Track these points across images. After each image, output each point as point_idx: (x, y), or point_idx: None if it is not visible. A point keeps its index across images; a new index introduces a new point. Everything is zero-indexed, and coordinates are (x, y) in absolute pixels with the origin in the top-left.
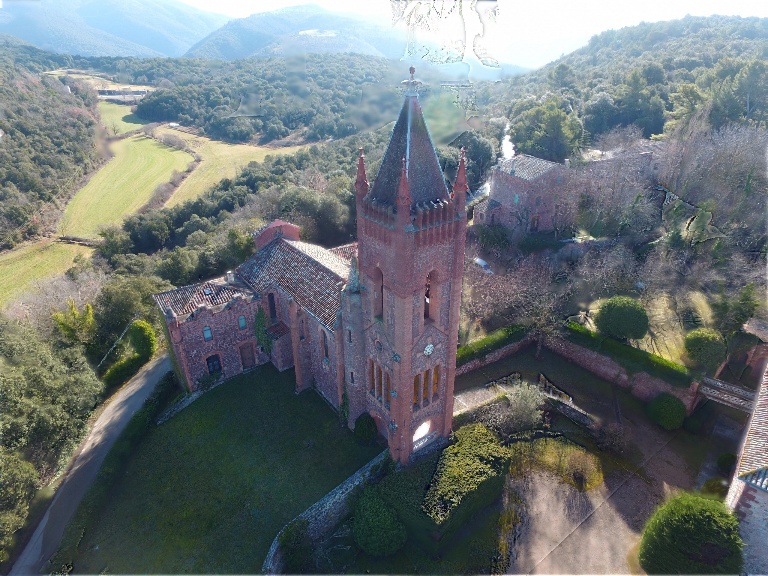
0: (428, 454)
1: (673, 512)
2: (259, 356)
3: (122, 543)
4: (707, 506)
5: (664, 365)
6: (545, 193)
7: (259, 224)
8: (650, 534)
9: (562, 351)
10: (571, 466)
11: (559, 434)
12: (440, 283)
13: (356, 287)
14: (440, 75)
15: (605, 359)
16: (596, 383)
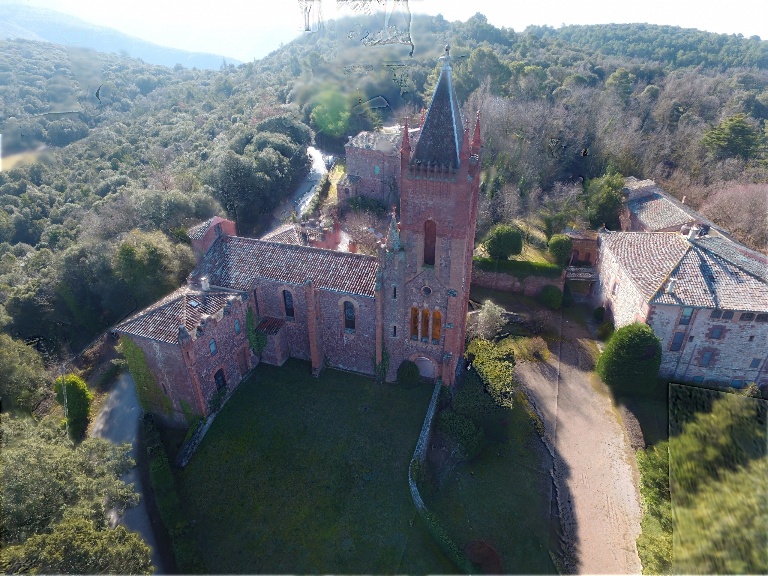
0: (460, 374)
1: (622, 339)
2: (251, 359)
3: (260, 572)
4: (638, 326)
5: (543, 266)
6: (399, 161)
7: (146, 235)
8: (610, 361)
9: None
10: (534, 348)
11: (508, 334)
12: (469, 224)
13: (398, 246)
14: (380, 56)
15: (502, 275)
16: (502, 295)
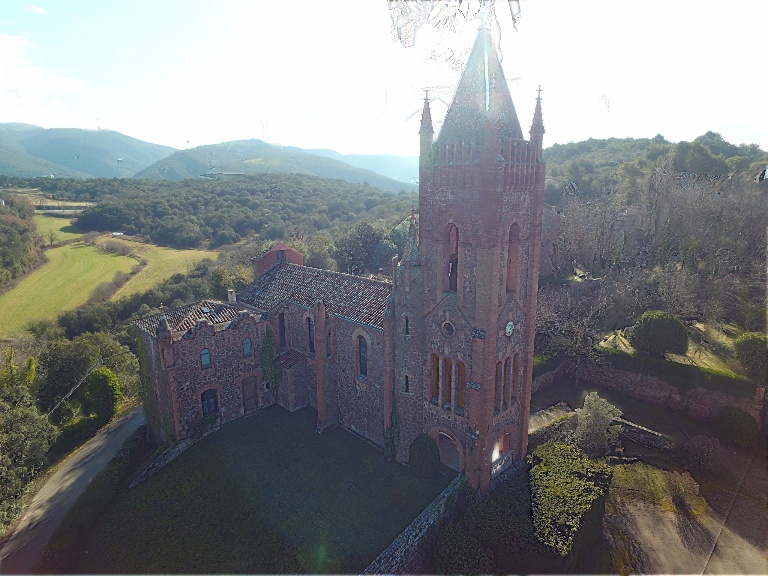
0: (509, 480)
1: None
2: (263, 395)
3: None
4: None
5: (720, 375)
6: None
7: None
8: None
9: (599, 380)
10: (671, 487)
11: (636, 459)
12: (521, 242)
13: (415, 260)
14: None
15: (651, 380)
16: (648, 408)
